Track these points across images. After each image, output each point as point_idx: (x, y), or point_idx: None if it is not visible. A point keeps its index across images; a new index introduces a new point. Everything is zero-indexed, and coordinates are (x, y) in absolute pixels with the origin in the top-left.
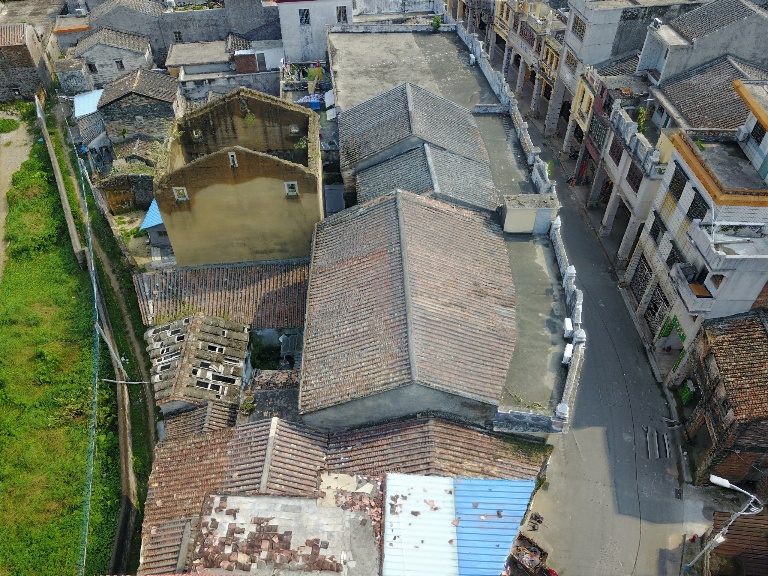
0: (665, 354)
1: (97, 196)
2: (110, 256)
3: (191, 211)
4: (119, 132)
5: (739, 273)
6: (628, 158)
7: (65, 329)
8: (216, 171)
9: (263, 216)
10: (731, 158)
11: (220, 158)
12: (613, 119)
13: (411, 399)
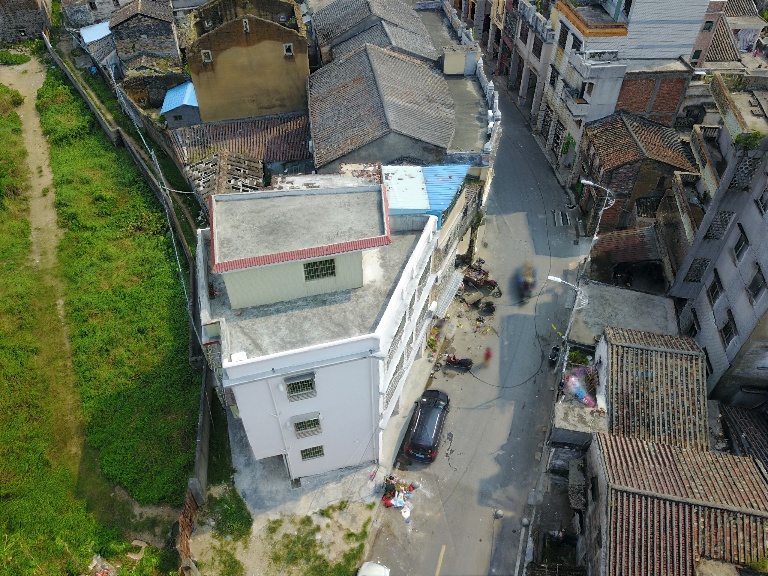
0: (567, 169)
1: (121, 91)
2: (136, 138)
3: (214, 71)
4: (127, 50)
5: (602, 80)
6: (532, 35)
7: (113, 183)
8: (233, 36)
9: (267, 75)
10: (596, 13)
11: (236, 24)
12: (520, 10)
13: (390, 147)
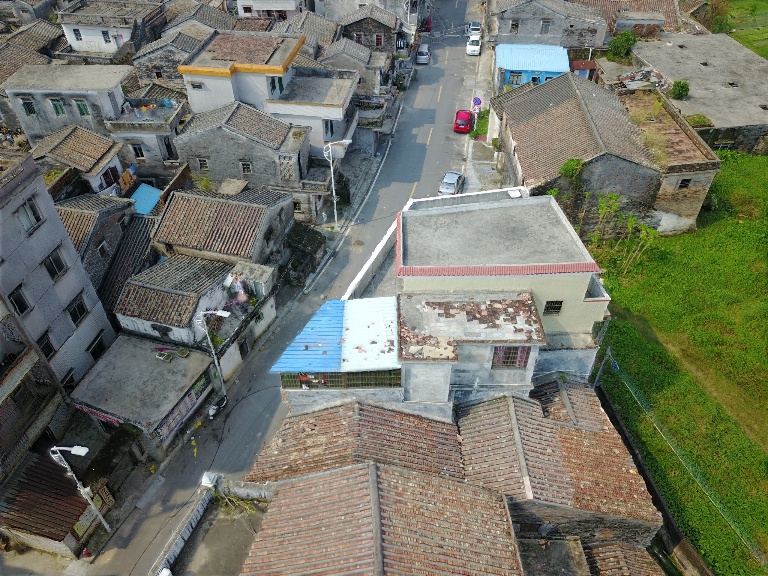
0: None
1: None
2: None
3: None
4: None
5: None
6: None
7: None
8: None
9: None
10: None
11: None
12: None
13: None
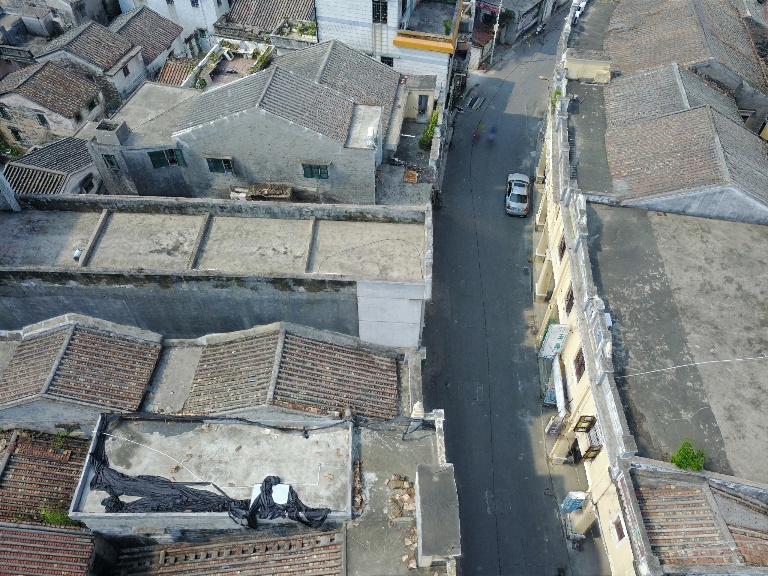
0: None
1: None
2: None
3: None
4: None
5: None
6: None
7: None
8: None
9: None
10: (419, 29)
11: None
12: None
13: None
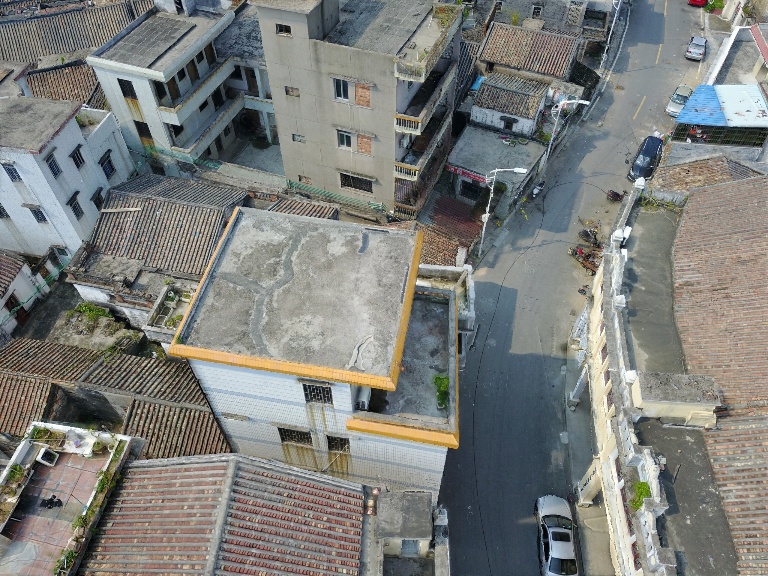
0: None
1: None
2: None
3: None
4: None
5: None
6: None
7: None
8: None
9: None
10: None
11: None
12: None
13: None
